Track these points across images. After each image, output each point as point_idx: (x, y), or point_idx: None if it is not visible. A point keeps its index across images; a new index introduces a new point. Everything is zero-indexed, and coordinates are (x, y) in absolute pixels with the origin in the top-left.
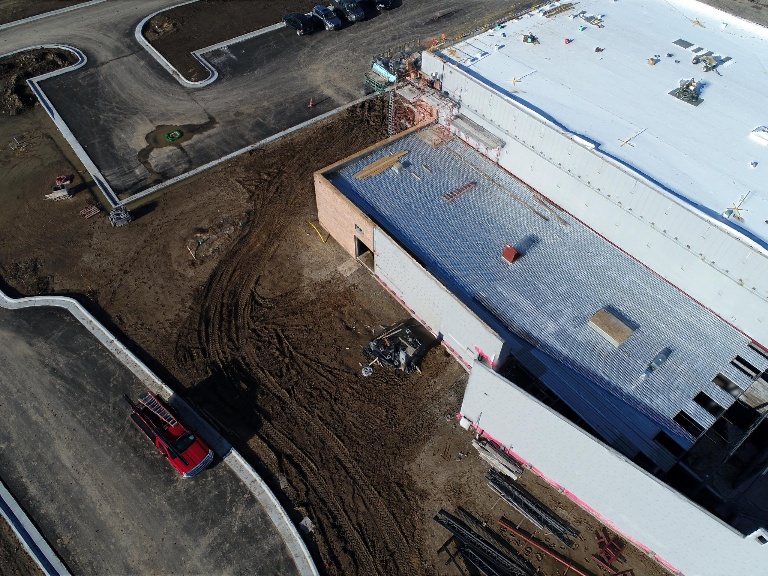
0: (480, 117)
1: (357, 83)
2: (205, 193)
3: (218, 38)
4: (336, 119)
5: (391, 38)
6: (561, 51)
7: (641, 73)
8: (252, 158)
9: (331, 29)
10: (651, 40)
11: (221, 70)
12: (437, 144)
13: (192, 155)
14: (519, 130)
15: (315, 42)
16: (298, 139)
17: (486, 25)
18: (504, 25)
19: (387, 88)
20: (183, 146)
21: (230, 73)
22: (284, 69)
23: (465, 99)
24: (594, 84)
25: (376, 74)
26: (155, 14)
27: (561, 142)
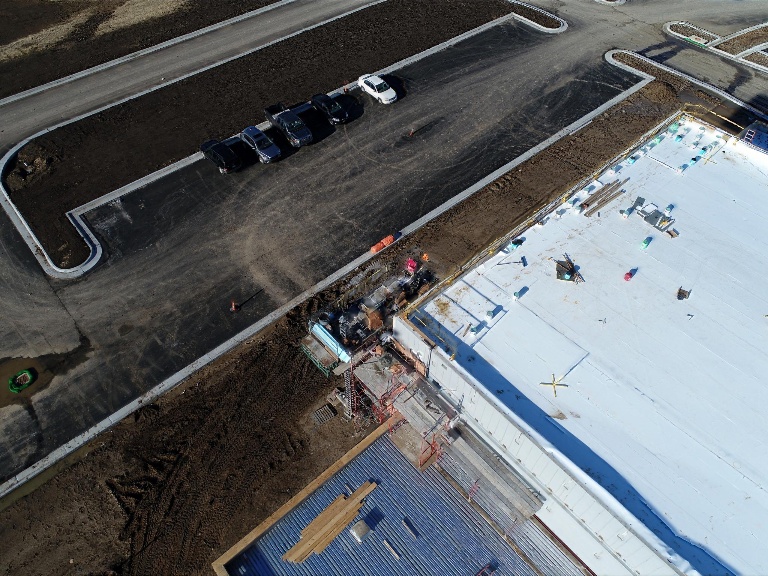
0: (498, 447)
1: (302, 259)
2: (54, 517)
3: (108, 184)
4: (270, 335)
5: (349, 173)
6: (622, 299)
7: (765, 353)
8: (137, 428)
9: (267, 162)
10: (759, 263)
11: (107, 243)
12: (424, 461)
13: (45, 424)
14: (574, 504)
15: (244, 184)
16: (211, 382)
17: (494, 244)
18: (521, 237)
19: (337, 368)
20: (33, 403)
21: (120, 248)
22: (198, 237)
23: (470, 409)
24: (692, 387)
25: (318, 343)
26: (25, 142)
27: (665, 572)
